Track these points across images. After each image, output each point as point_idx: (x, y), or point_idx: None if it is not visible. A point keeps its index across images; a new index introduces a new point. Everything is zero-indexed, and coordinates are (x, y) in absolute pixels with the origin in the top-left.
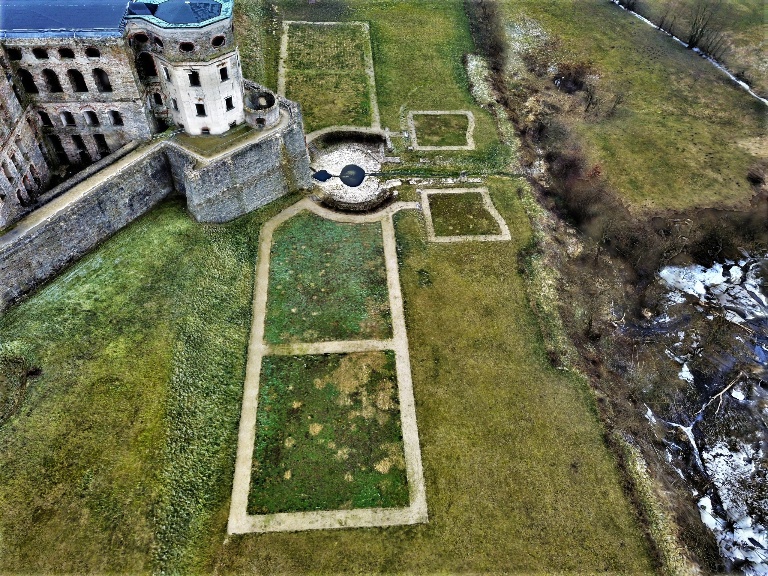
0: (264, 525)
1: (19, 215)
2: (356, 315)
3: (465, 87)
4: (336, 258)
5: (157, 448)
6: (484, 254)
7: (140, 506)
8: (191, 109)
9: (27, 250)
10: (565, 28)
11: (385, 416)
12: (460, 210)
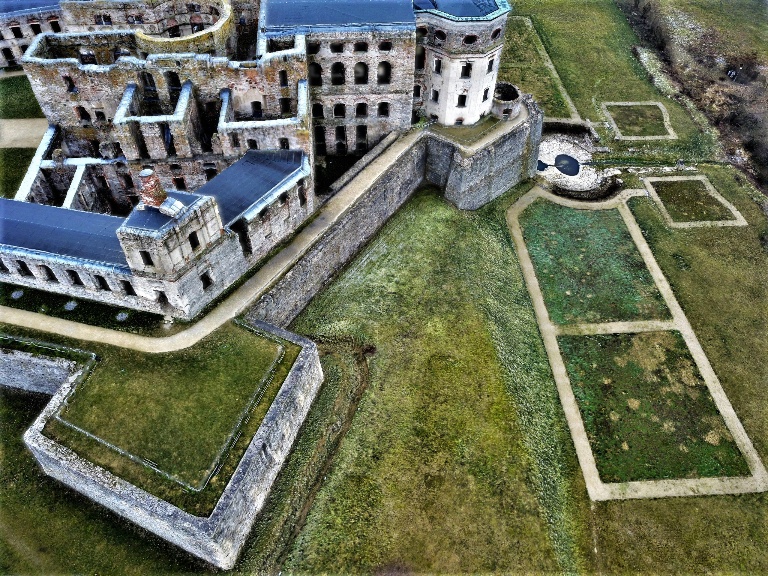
0: (622, 493)
1: (321, 202)
2: (630, 297)
3: (646, 79)
4: (589, 243)
5: (511, 420)
6: (727, 239)
7: (516, 473)
8: (453, 100)
9: (340, 235)
10: (718, 20)
11: (695, 392)
12: (688, 197)
